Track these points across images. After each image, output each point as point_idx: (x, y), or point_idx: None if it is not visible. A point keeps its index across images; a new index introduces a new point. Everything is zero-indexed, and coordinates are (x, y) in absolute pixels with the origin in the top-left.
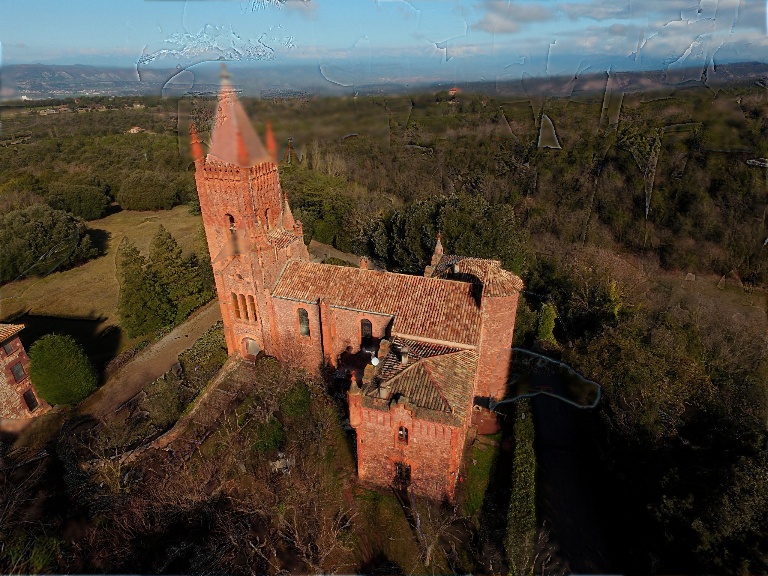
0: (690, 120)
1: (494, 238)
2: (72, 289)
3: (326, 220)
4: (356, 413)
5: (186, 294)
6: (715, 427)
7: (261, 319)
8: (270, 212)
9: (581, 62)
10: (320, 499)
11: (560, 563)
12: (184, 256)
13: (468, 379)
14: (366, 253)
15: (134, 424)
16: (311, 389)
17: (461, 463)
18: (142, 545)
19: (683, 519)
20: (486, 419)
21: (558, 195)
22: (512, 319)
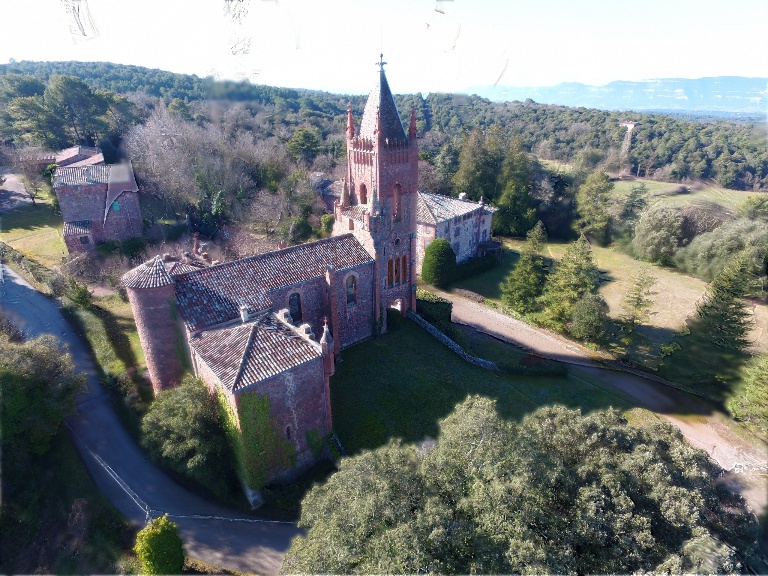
0: None
1: None
2: None
3: None
4: None
5: None
6: None
7: None
8: None
9: None
10: None
11: (69, 345)
12: None
13: None
14: None
15: None
16: None
17: None
18: None
19: None
20: None
21: None
22: None
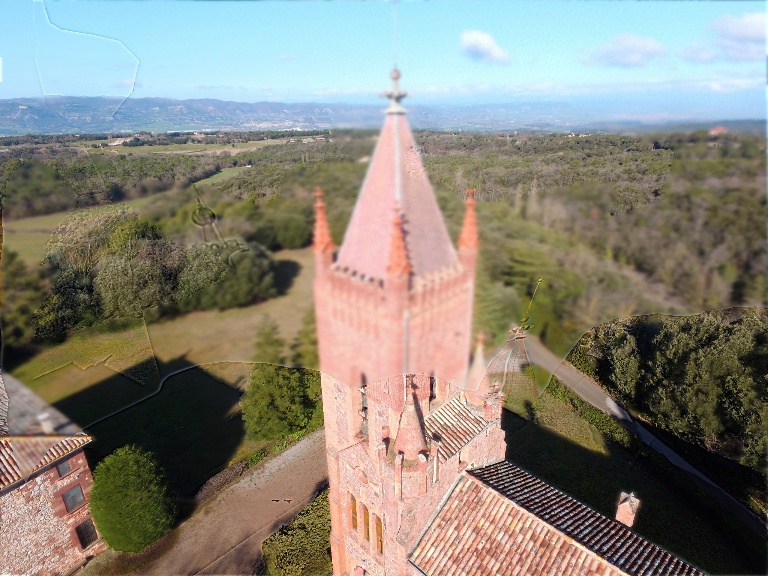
0: None
1: None
2: None
3: None
4: None
5: None
6: None
7: (386, 575)
8: None
9: None
10: None
11: None
12: None
13: None
14: (592, 370)
15: None
16: None
17: None
18: None
19: None
20: None
21: None
22: None
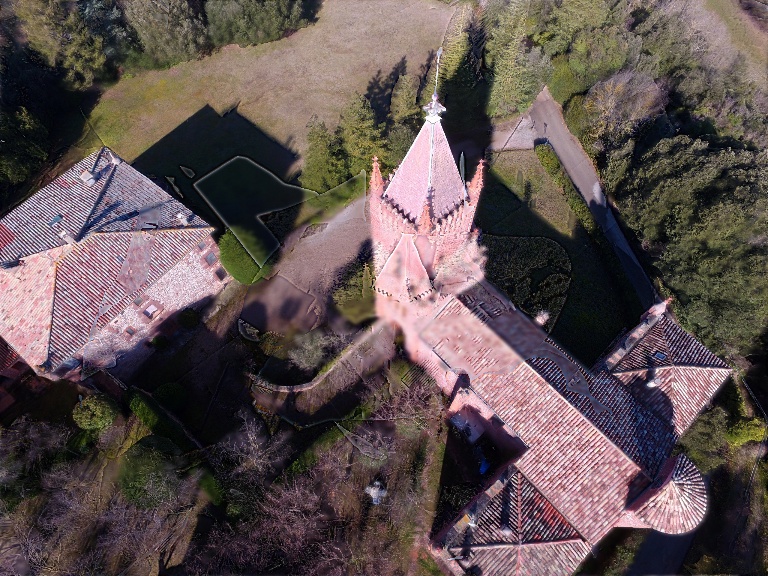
0: None
1: None
2: (277, 81)
3: (571, 67)
4: None
5: None
6: None
7: None
8: None
9: None
10: (392, 544)
11: None
12: (390, 59)
13: None
14: (595, 154)
15: None
16: None
17: None
18: (250, 572)
19: None
20: None
21: None
22: None
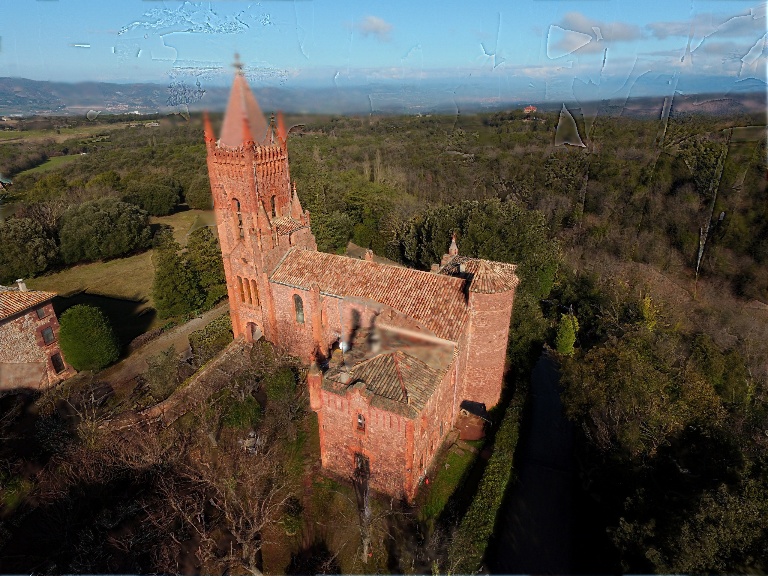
0: (748, 123)
1: (521, 245)
2: (127, 273)
3: (365, 224)
4: (315, 395)
5: (215, 282)
6: (724, 458)
7: (261, 303)
8: (277, 199)
9: (642, 69)
10: (278, 481)
11: None
12: None
13: (438, 374)
14: (398, 257)
15: (140, 395)
16: (302, 377)
17: (432, 465)
18: None
19: (642, 548)
20: (472, 425)
21: (609, 209)
22: (504, 319)
